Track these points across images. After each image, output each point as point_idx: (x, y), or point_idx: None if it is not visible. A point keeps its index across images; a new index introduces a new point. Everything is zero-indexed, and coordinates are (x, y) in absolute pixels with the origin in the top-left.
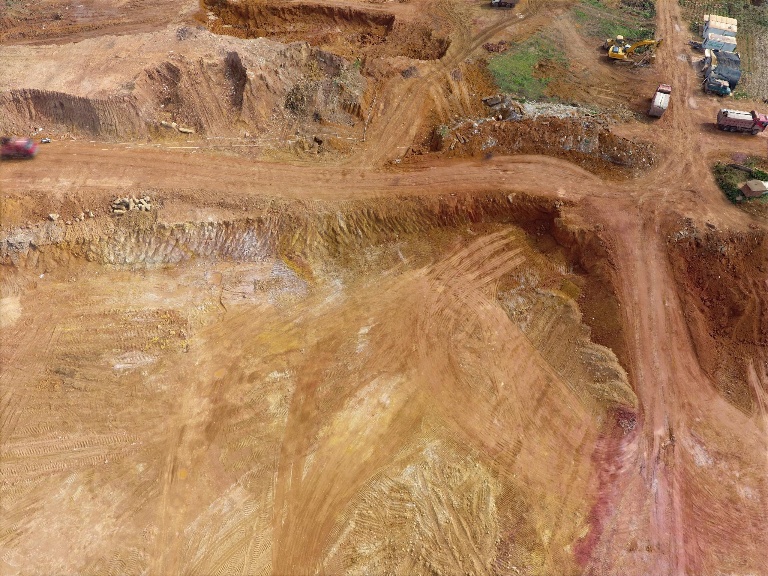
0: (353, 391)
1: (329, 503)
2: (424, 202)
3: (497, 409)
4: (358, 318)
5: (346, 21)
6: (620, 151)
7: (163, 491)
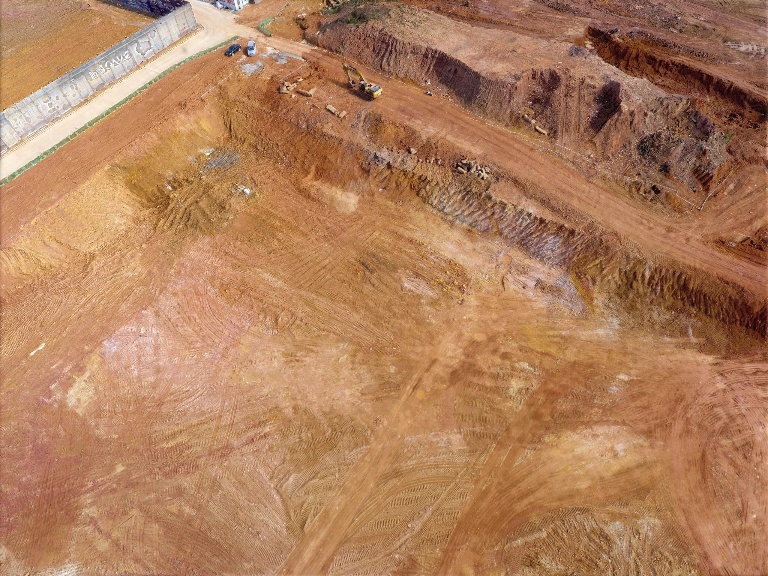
0: (591, 423)
1: (530, 501)
2: (747, 296)
3: (738, 536)
4: (622, 363)
5: (720, 94)
6: None
7: (402, 398)
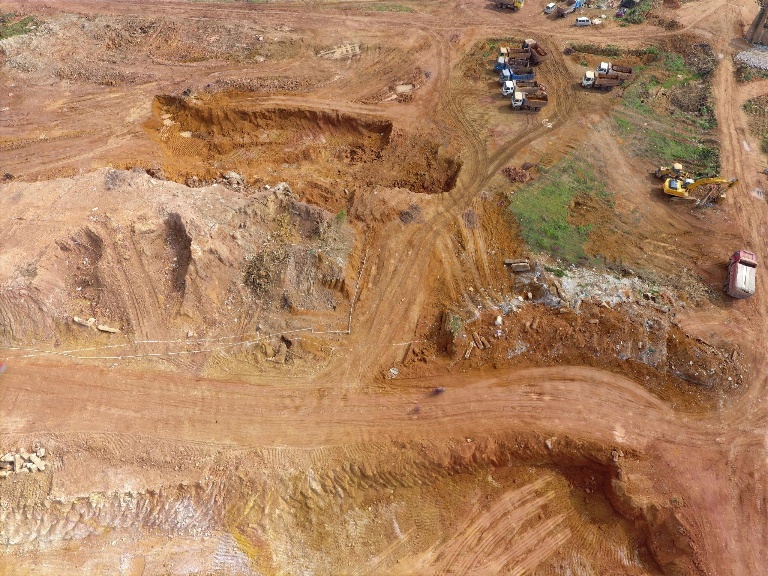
0: None
1: None
2: (429, 452)
3: None
4: None
5: (332, 127)
6: (698, 368)
7: None
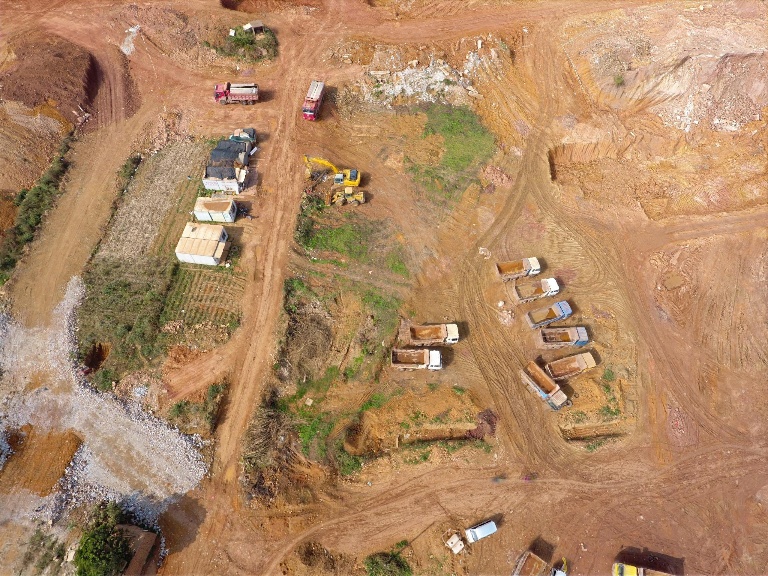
0: None
1: None
2: (491, 6)
3: None
4: None
5: None
6: None
7: None
